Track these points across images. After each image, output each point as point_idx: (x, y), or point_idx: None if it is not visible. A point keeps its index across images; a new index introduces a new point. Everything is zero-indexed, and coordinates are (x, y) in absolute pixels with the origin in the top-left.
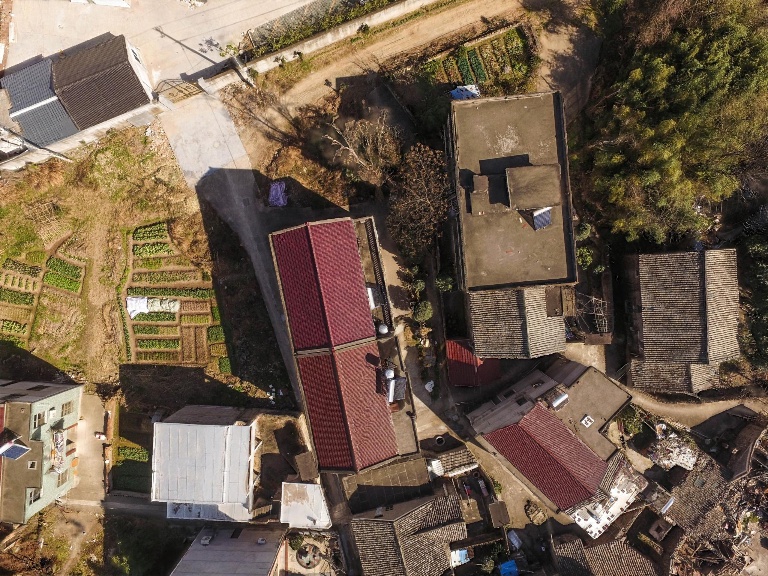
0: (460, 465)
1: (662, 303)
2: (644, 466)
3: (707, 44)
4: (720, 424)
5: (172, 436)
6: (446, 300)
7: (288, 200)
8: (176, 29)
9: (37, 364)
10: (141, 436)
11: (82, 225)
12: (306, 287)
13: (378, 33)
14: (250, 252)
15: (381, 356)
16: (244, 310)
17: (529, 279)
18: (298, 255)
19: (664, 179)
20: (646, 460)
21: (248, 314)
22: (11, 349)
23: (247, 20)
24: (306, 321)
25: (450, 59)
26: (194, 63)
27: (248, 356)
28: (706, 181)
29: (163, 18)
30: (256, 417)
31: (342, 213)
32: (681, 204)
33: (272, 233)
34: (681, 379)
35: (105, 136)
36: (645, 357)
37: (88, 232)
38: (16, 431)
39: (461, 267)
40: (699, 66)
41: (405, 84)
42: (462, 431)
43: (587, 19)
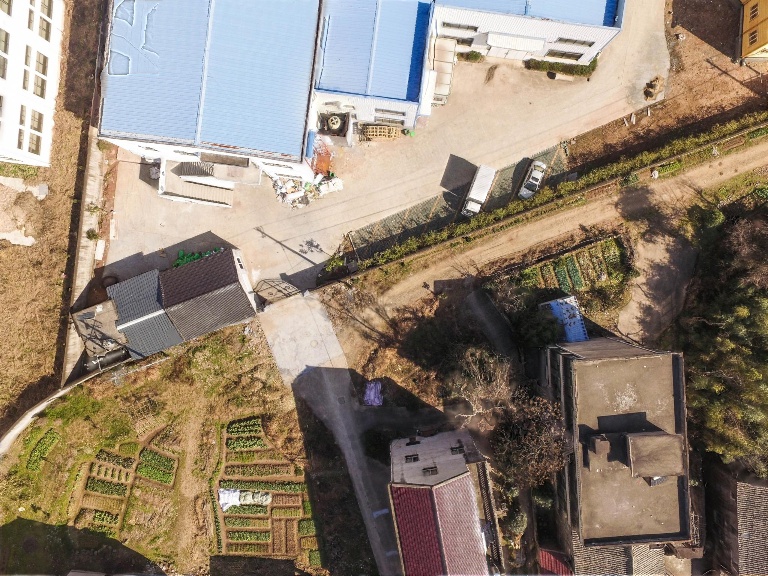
0: None
1: (760, 533)
2: None
3: None
4: None
5: None
6: None
7: (383, 400)
8: (277, 230)
9: (128, 555)
10: None
11: (177, 418)
12: (427, 544)
13: (478, 239)
14: (344, 450)
15: None
16: (337, 508)
17: (642, 533)
18: (419, 512)
19: None
20: None
21: (341, 511)
22: (102, 539)
23: (348, 222)
24: (424, 574)
25: (548, 265)
26: (294, 263)
27: (339, 552)
28: None
29: (264, 219)
30: None
31: (436, 414)
32: None
33: (392, 485)
34: None
35: None
36: None
37: (182, 425)
38: None
39: None
40: None
41: None
42: None
43: (684, 230)
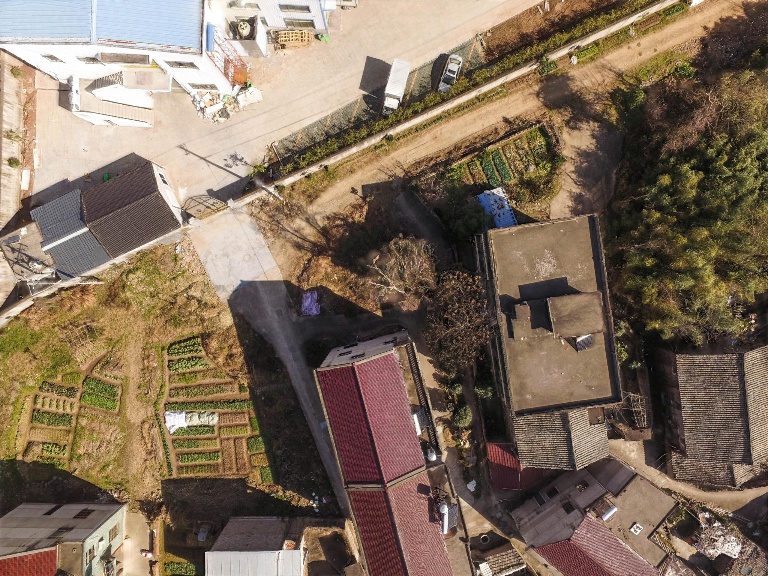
0: (508, 566)
1: (702, 403)
2: (688, 552)
3: (734, 150)
4: (761, 507)
5: (224, 564)
6: (483, 400)
7: (321, 309)
8: (200, 146)
9: (79, 485)
10: (187, 551)
11: (116, 344)
12: (355, 424)
13: (402, 139)
14: (286, 362)
15: (431, 484)
16: (283, 421)
17: (574, 399)
18: (345, 392)
19: (698, 283)
20: (690, 546)
21: (287, 424)
22: (52, 471)
23: (270, 133)
24: (356, 456)
25: (474, 161)
26: (220, 179)
27: (289, 465)
28: (739, 281)
29: (187, 136)
30: (303, 532)
31: (375, 319)
32: (716, 306)
33: (317, 369)
34: (723, 473)
35: (135, 256)
36: (687, 455)
37: (123, 351)
38: (69, 571)
39: (503, 384)
40: (728, 174)
41: (435, 199)
42: (506, 528)
43: (608, 114)
